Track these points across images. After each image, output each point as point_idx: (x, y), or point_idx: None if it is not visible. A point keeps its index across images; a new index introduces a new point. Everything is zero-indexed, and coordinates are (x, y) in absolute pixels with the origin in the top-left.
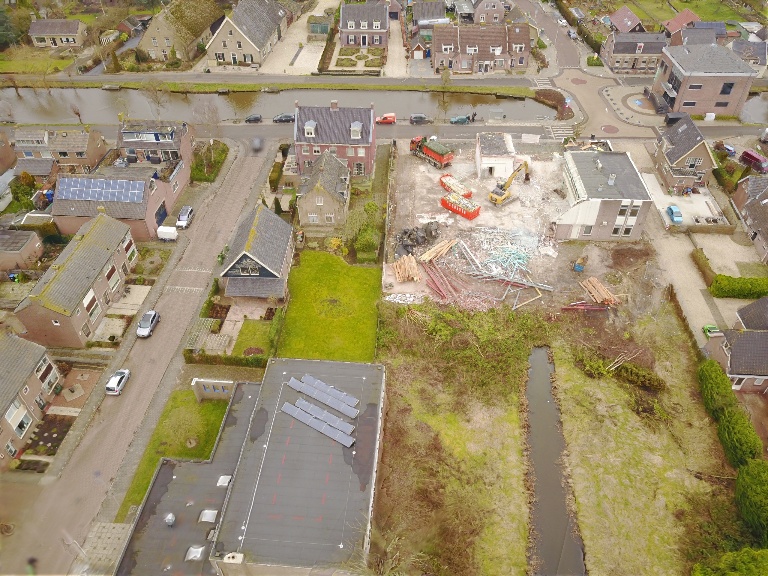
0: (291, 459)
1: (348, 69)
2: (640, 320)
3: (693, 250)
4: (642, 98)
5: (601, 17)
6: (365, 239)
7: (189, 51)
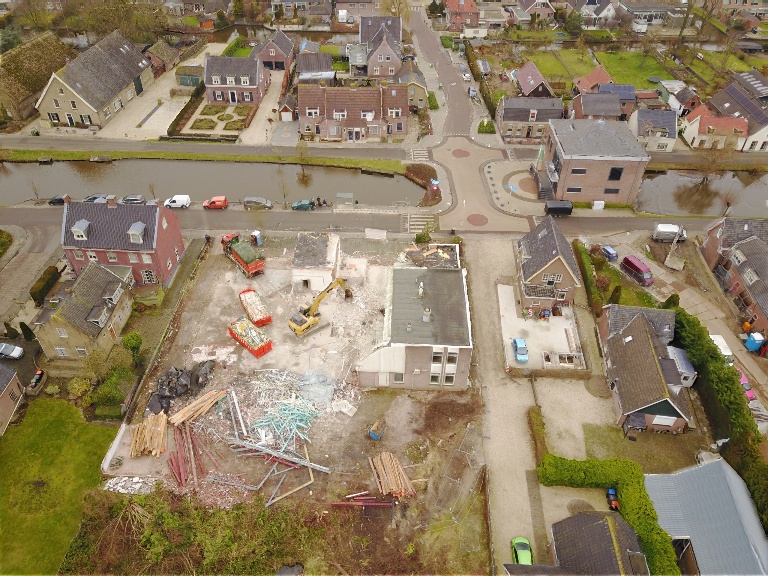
0: None
1: (203, 132)
2: (435, 522)
3: (529, 408)
4: (527, 177)
5: (511, 70)
6: (102, 392)
7: (21, 109)
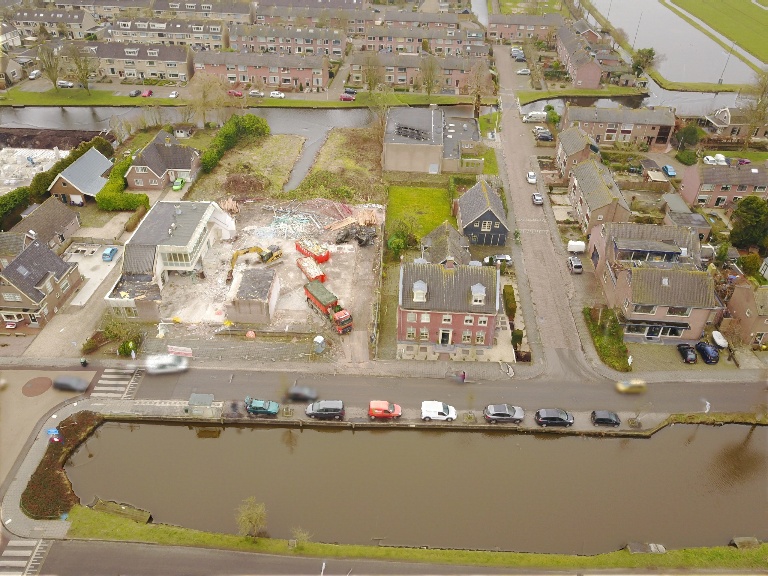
0: (421, 123)
1: None
2: (214, 199)
3: None
4: None
5: None
6: None
7: None
